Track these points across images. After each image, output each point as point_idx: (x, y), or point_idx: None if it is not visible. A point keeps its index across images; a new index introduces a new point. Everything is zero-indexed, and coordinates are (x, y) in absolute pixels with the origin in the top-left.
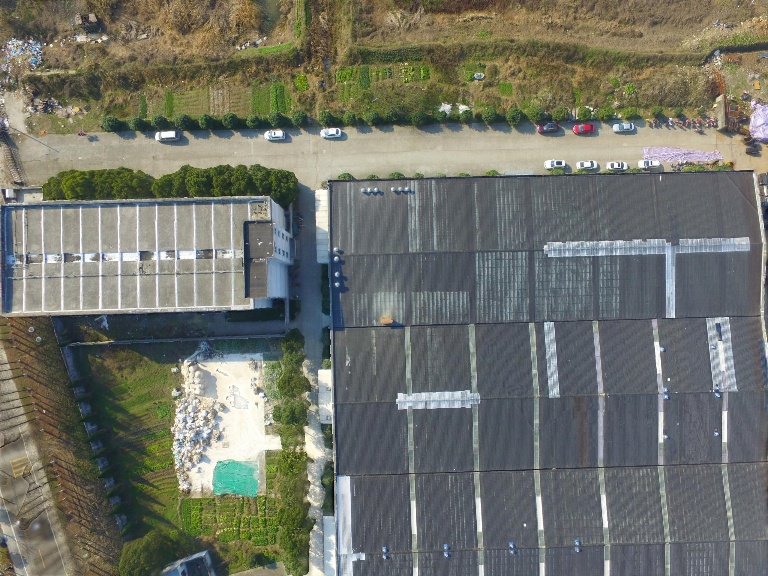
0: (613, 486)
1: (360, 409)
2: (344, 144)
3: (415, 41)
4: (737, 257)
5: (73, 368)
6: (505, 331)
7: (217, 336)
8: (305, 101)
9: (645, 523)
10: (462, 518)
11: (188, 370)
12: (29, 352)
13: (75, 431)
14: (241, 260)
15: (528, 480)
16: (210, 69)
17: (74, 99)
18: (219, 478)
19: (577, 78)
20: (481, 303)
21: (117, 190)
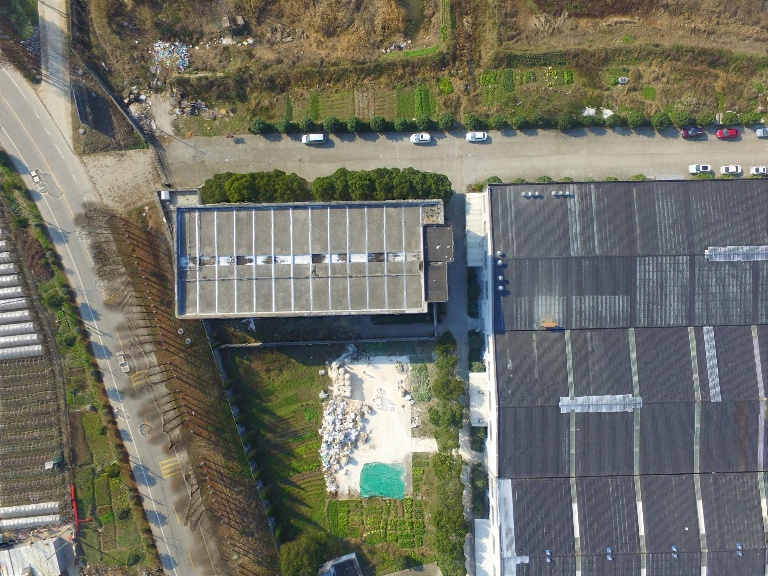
0: None
1: (523, 412)
2: (489, 147)
3: (560, 45)
4: None
5: (222, 370)
6: (665, 335)
7: (365, 338)
8: (451, 104)
9: None
10: (624, 522)
11: (338, 372)
12: (178, 354)
13: (224, 433)
14: (413, 263)
15: (688, 484)
16: (356, 72)
17: (221, 101)
18: (366, 480)
19: (720, 83)
20: (641, 307)
21: (281, 193)
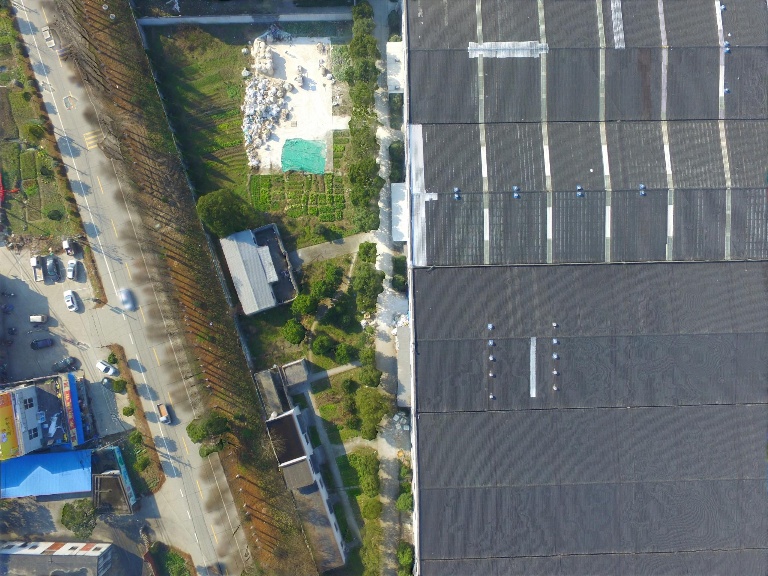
0: (676, 137)
1: (433, 56)
2: None
3: None
4: None
5: (146, 44)
6: None
7: None
8: None
9: (707, 170)
10: (531, 163)
11: (259, 46)
12: (103, 29)
13: (148, 105)
14: None
15: (594, 130)
16: None
17: None
18: (288, 156)
19: None
20: None
21: None
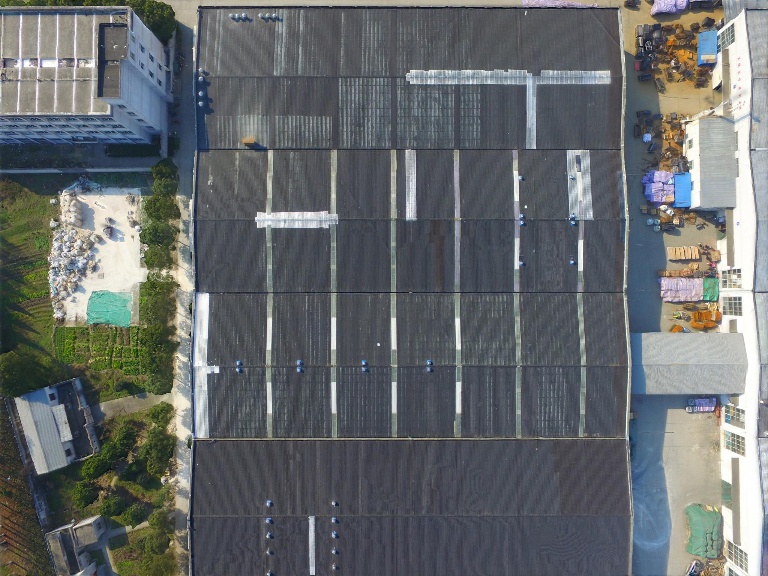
0: (468, 311)
1: (220, 226)
2: None
3: None
4: (598, 90)
5: None
6: (367, 157)
7: None
8: None
9: (498, 346)
10: (317, 336)
11: (65, 199)
12: None
13: None
14: None
15: (384, 302)
16: None
17: None
18: (93, 308)
19: None
20: (344, 128)
21: None
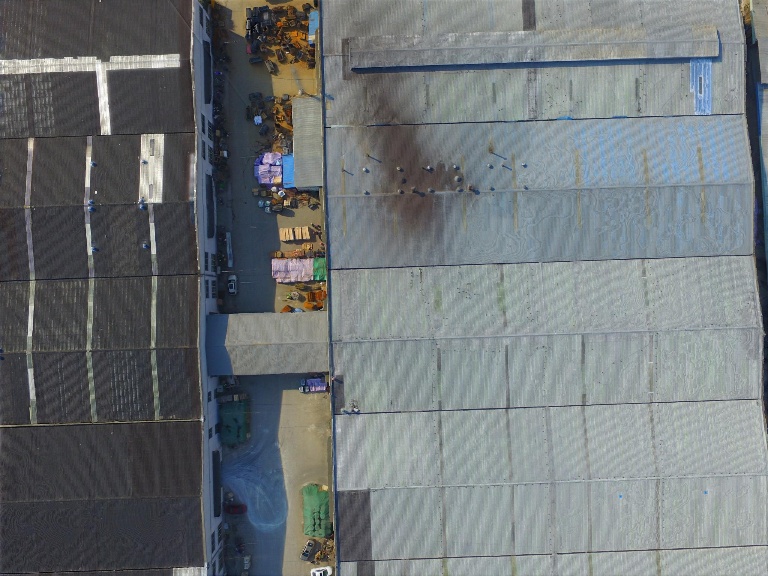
0: (42, 298)
1: None
2: None
3: None
4: (168, 73)
5: None
6: None
7: None
8: None
9: (69, 332)
10: None
11: None
12: None
13: None
14: None
15: None
16: None
17: None
18: None
19: None
20: None
21: None
